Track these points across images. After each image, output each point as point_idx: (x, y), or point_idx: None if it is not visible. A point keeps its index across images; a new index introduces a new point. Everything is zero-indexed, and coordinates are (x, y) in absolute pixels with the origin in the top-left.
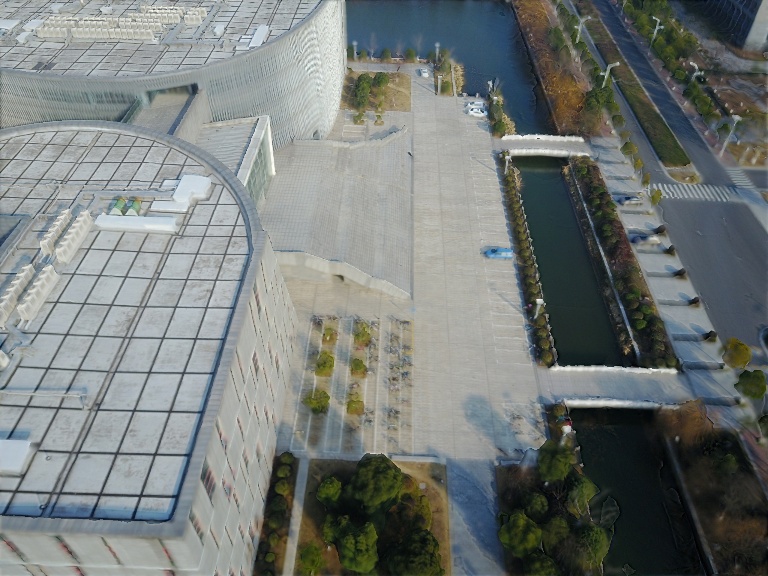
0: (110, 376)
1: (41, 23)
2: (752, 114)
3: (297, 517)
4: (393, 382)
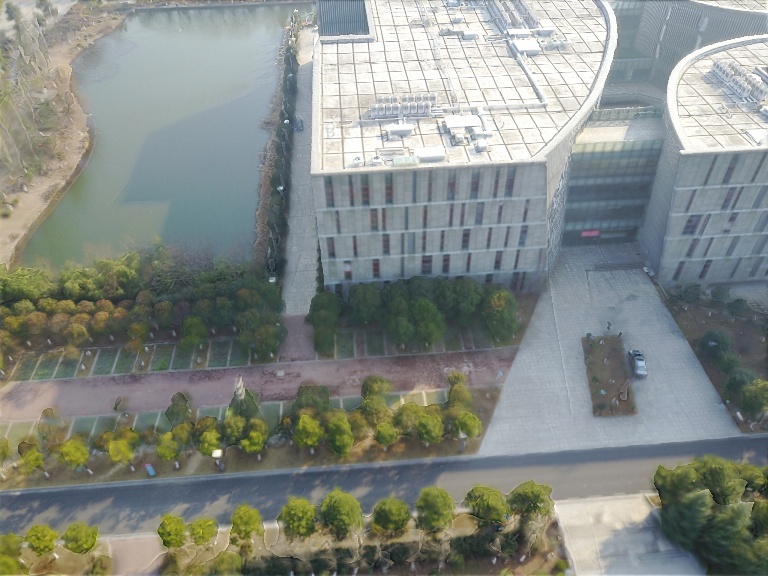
0: None
1: None
2: None
3: None
4: None
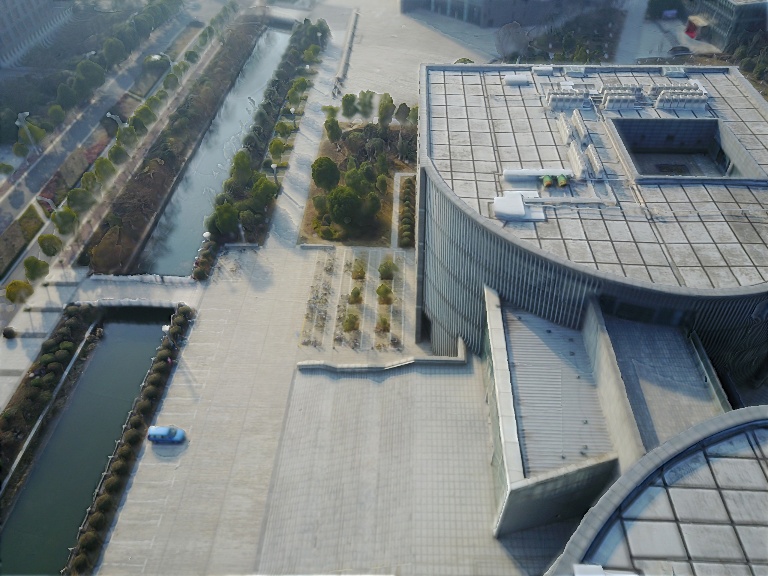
0: (488, 106)
1: None
2: None
3: (395, 221)
4: (326, 292)
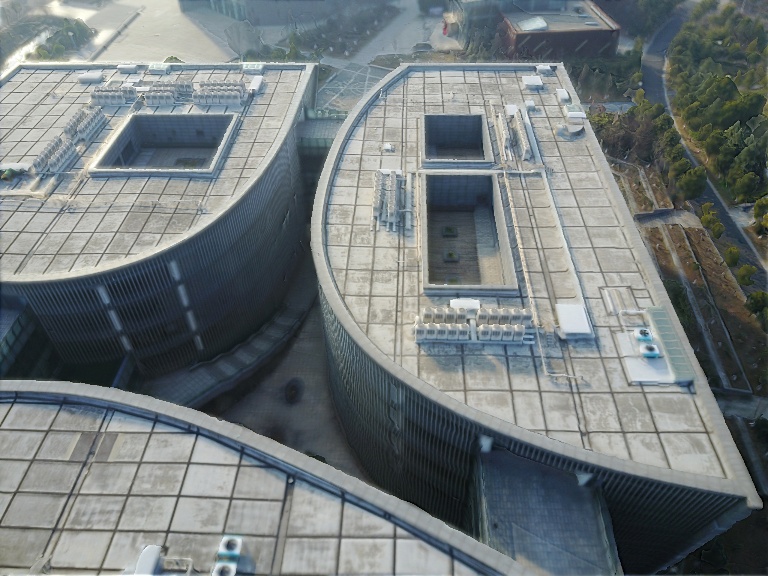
0: (40, 103)
1: None
2: None
3: None
4: None
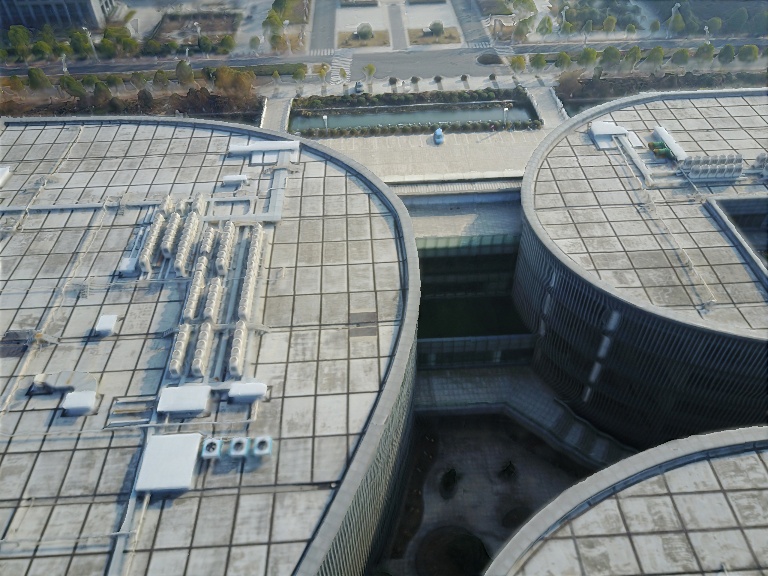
0: None
1: (182, 387)
2: (272, 21)
3: None
4: None
